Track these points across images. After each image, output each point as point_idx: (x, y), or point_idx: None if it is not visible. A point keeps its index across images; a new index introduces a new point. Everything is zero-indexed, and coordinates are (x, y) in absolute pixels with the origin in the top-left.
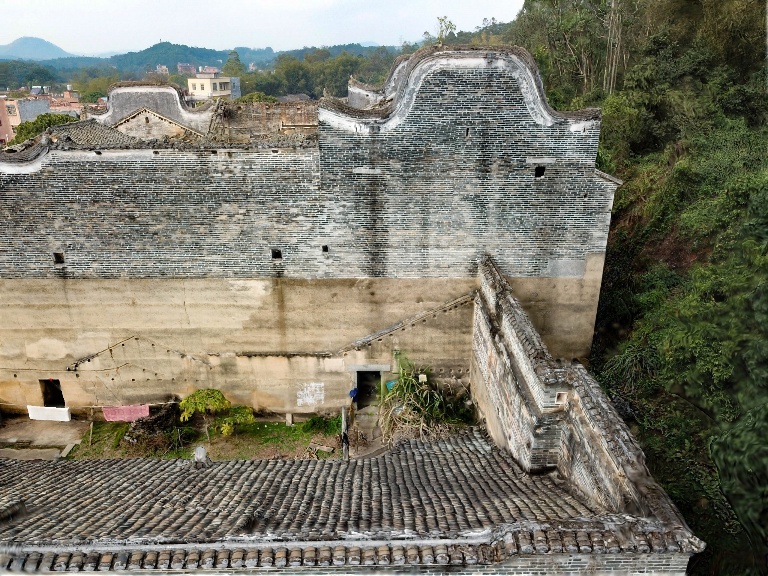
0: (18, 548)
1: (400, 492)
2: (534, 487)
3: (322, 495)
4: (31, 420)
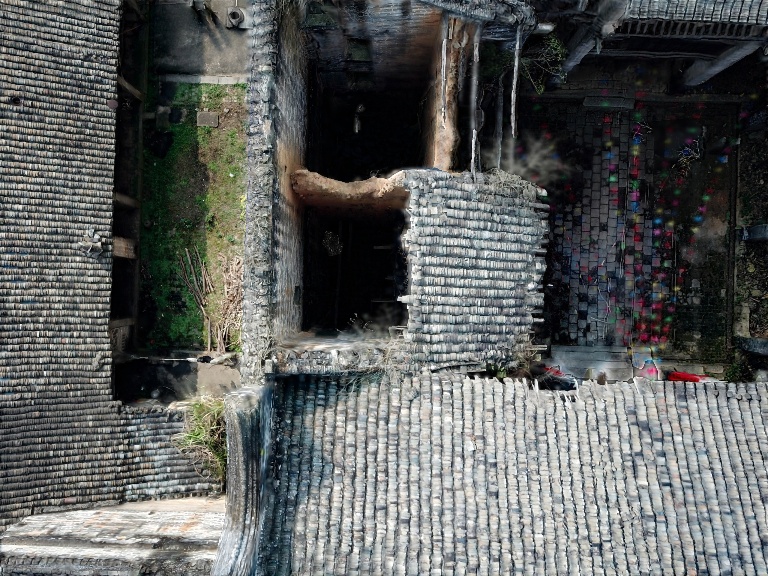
0: None
1: (5, 415)
2: (7, 516)
3: (2, 357)
4: None
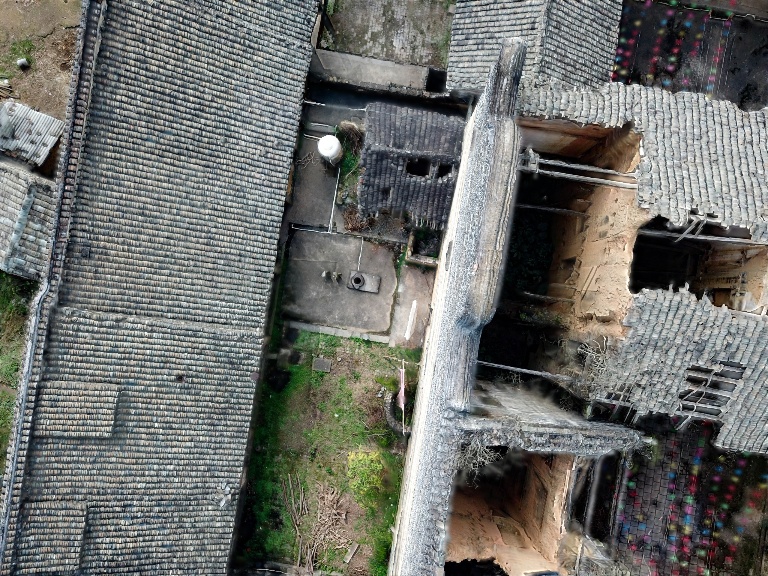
0: (7, 484)
1: None
2: None
3: None
4: (430, 293)
